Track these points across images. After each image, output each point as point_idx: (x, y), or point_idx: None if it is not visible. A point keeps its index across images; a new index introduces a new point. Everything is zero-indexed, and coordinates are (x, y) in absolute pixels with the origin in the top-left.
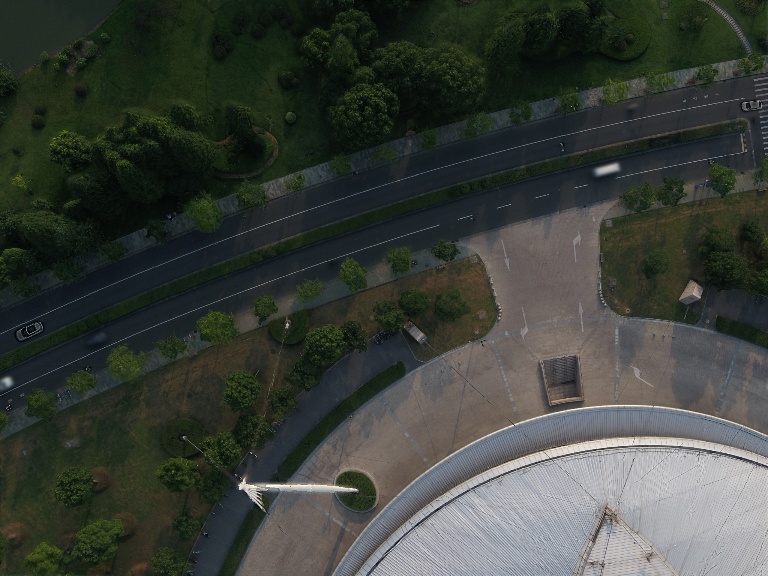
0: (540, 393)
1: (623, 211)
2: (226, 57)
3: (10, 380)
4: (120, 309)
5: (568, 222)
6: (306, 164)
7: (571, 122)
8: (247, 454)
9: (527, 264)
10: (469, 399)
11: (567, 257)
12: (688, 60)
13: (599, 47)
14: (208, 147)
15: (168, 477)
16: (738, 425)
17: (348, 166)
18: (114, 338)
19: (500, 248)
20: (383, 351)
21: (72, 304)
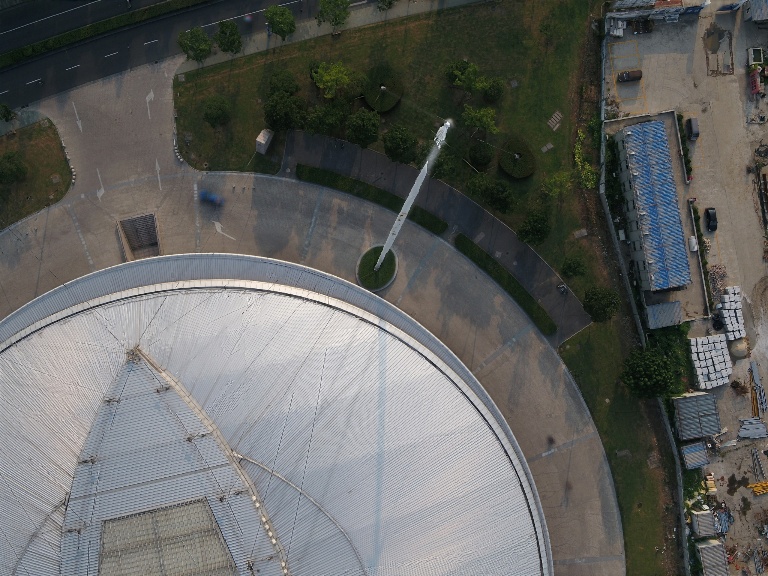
0: (119, 254)
1: (196, 64)
2: None
3: None
4: None
5: (140, 79)
6: None
7: None
8: None
9: (100, 125)
10: (47, 265)
11: (141, 115)
12: None
13: None
14: None
15: None
16: (301, 266)
17: None
18: None
19: (71, 110)
20: None
21: None
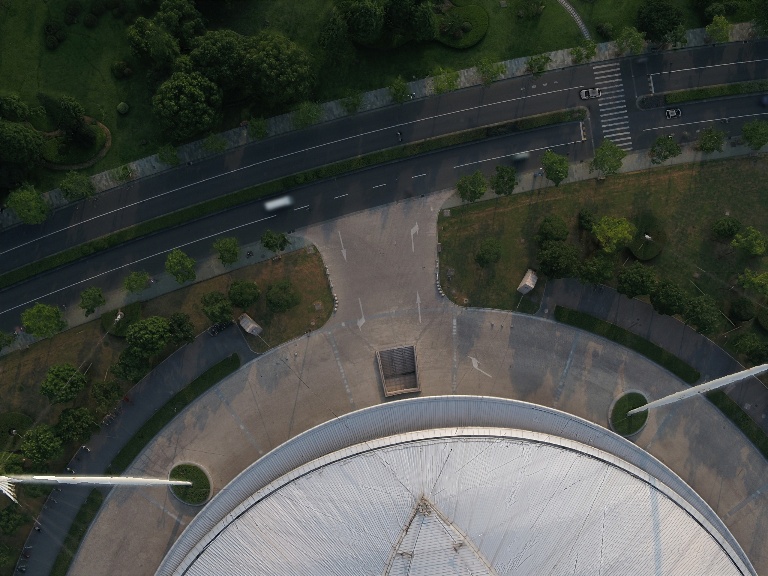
0: (377, 384)
1: (461, 200)
2: (58, 47)
3: None
4: None
5: (406, 212)
6: (139, 155)
7: (408, 111)
8: (80, 448)
9: (364, 254)
10: (305, 391)
11: (405, 247)
12: (526, 48)
13: (430, 35)
14: (28, 138)
15: None
16: (568, 415)
17: (175, 156)
18: None
19: (337, 238)
20: (218, 343)
21: None
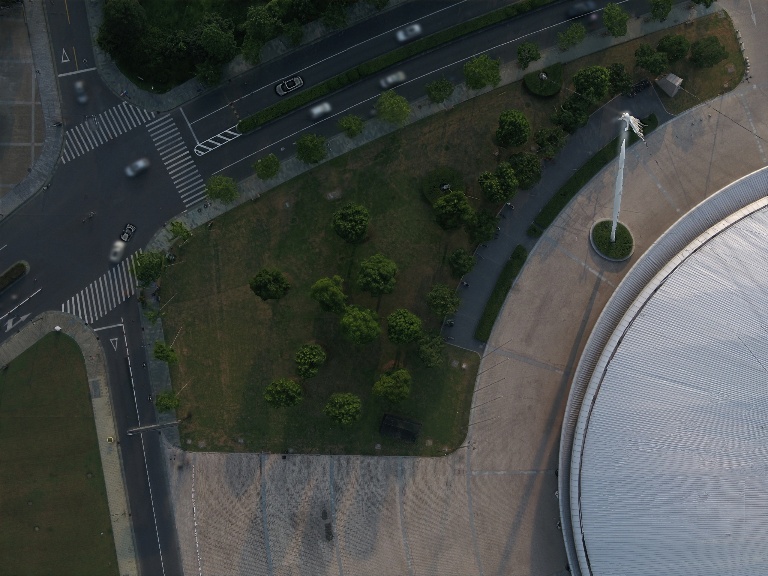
0: None
1: None
2: None
3: (271, 134)
4: (379, 62)
5: None
6: None
7: None
8: (504, 206)
9: None
10: (720, 151)
11: None
12: None
13: None
14: None
15: (450, 207)
16: None
17: None
18: (372, 93)
19: (746, 4)
20: (635, 104)
21: (330, 59)
